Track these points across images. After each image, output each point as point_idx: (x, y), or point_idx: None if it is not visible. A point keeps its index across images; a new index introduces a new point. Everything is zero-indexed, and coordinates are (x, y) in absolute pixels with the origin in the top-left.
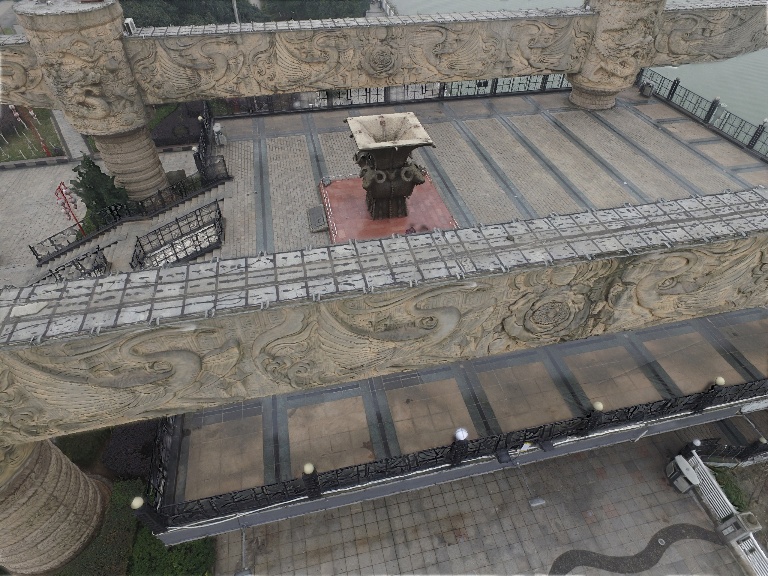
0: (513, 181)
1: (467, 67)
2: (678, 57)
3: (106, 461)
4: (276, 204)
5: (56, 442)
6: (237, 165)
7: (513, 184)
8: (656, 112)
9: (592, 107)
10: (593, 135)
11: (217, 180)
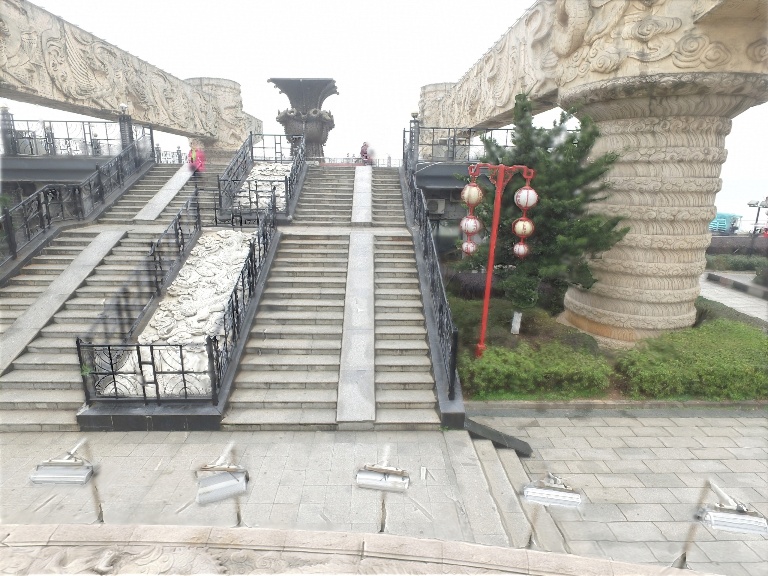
0: None
1: (179, 118)
2: None
3: (543, 288)
4: None
5: (522, 316)
6: None
7: None
8: None
9: None
10: None
11: (146, 162)
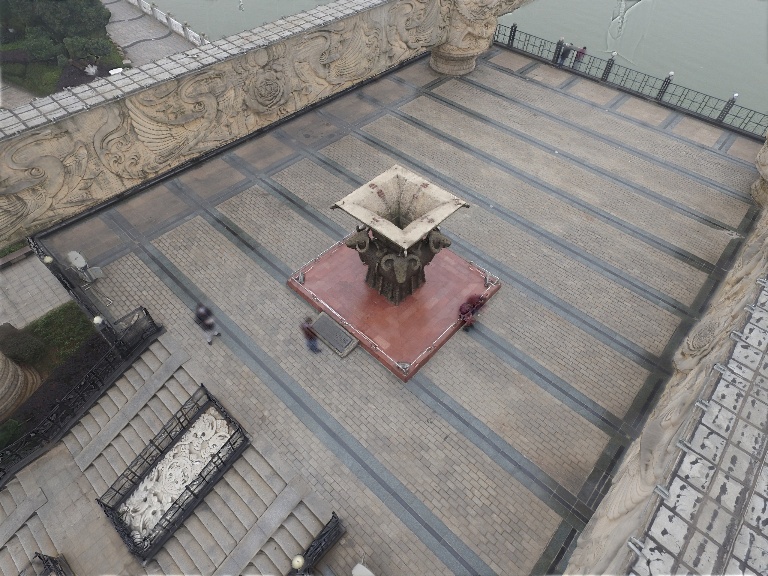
0: (473, 188)
1: (354, 68)
2: (512, 4)
3: None
4: (261, 338)
5: None
6: (148, 302)
7: (476, 192)
8: (510, 62)
9: (461, 73)
10: (487, 106)
11: (143, 341)
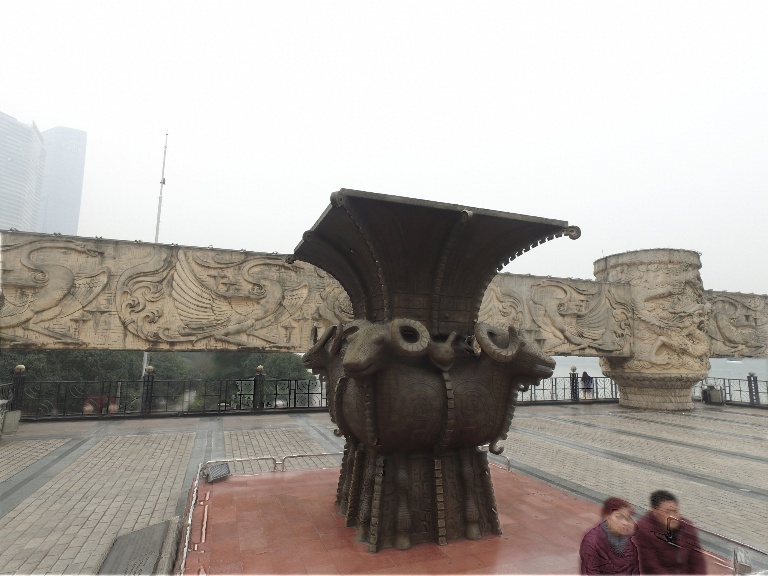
0: (689, 469)
1: None
2: (736, 347)
3: None
4: (1, 533)
5: None
6: None
7: (698, 472)
8: (760, 412)
9: (668, 406)
10: (720, 426)
11: None
